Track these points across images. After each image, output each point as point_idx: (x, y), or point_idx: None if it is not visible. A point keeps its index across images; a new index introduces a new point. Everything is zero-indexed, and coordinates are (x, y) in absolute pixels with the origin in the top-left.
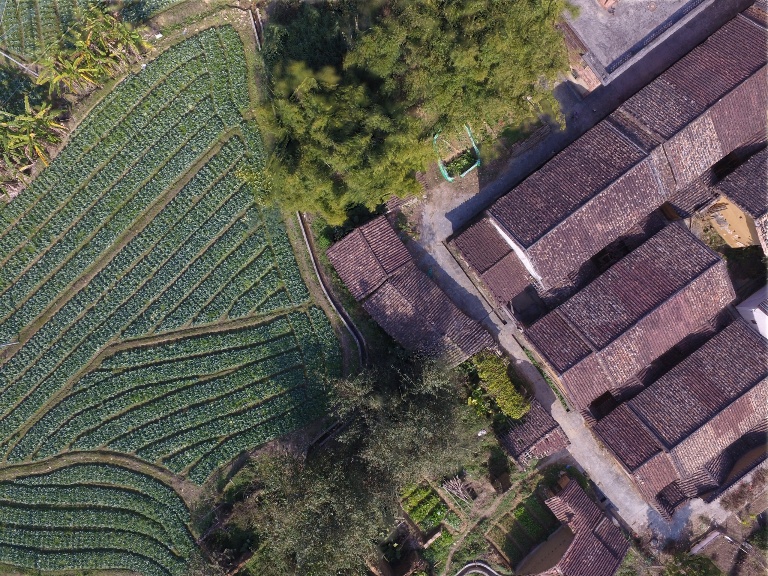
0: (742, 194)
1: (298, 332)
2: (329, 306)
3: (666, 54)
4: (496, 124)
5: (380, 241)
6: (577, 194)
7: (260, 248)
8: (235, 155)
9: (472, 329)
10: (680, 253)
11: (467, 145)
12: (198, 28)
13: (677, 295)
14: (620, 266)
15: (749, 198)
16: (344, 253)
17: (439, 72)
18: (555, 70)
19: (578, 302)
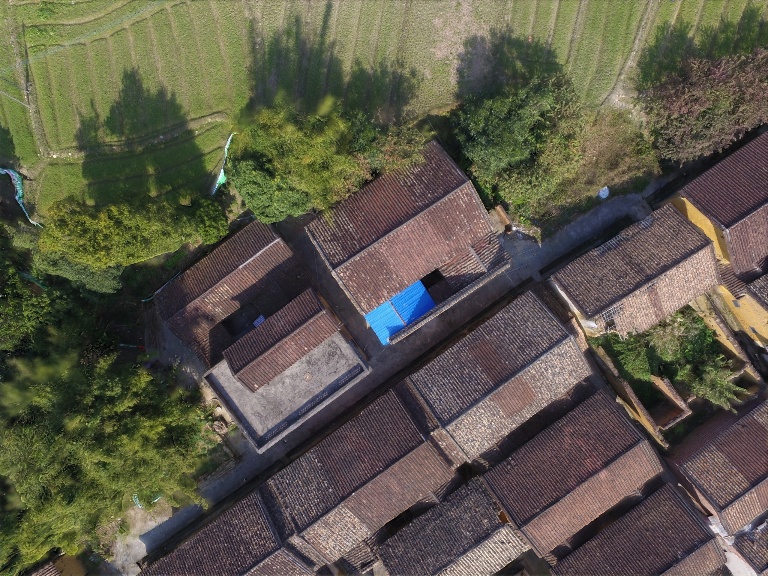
0: (396, 565)
1: None
2: None
3: (357, 388)
4: (186, 453)
5: None
6: None
7: None
8: None
9: None
10: None
11: None
12: None
13: None
14: None
15: (401, 571)
16: None
17: (36, 497)
18: (168, 482)
19: None
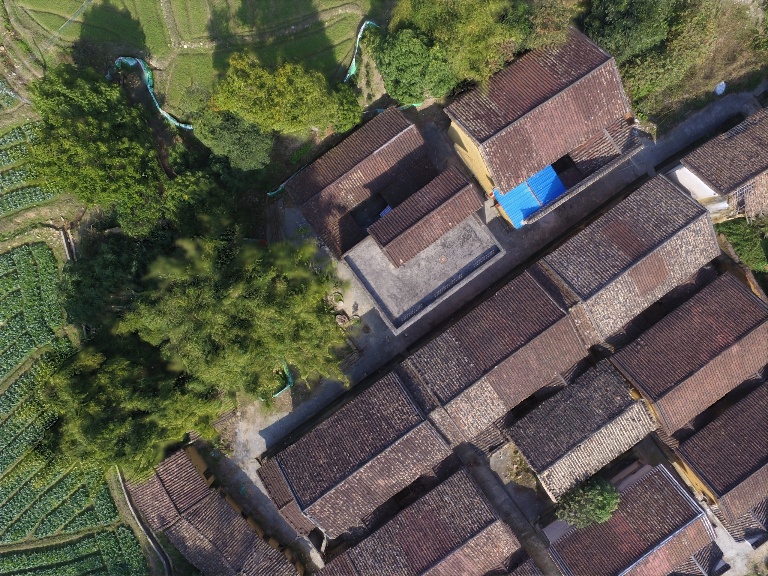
0: (529, 444)
1: (105, 552)
2: (137, 525)
3: (476, 282)
4: None
5: (176, 478)
6: (357, 453)
7: (69, 466)
8: (45, 373)
9: (273, 560)
10: (463, 506)
11: (280, 365)
12: (10, 245)
13: (455, 553)
14: (409, 512)
15: (534, 450)
16: (141, 487)
17: (198, 359)
18: (322, 349)
19: (366, 549)
